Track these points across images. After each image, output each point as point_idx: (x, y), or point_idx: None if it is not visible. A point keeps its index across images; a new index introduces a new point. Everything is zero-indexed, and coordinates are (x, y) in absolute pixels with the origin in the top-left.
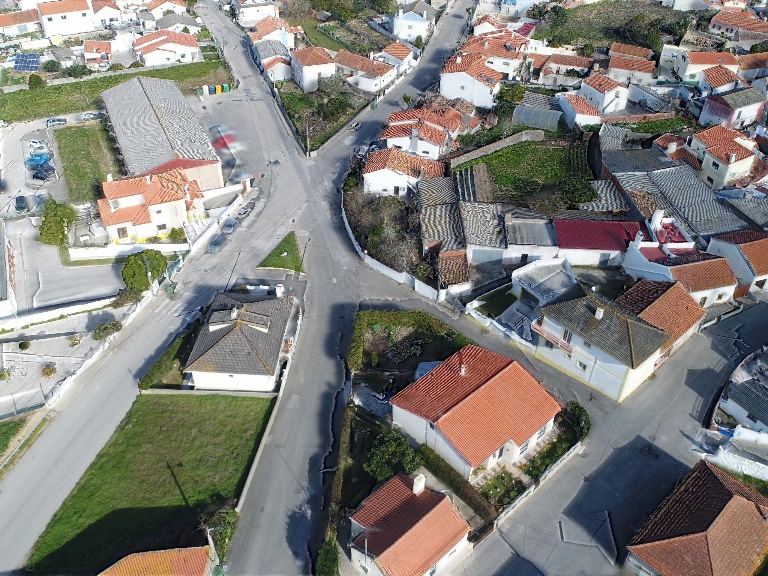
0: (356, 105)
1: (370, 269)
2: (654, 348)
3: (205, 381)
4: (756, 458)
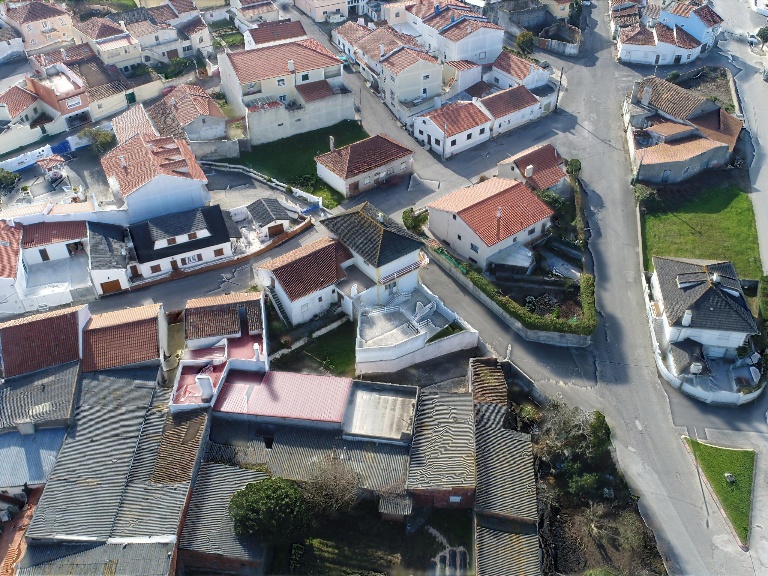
0: None
1: None
2: None
3: None
4: (297, 202)
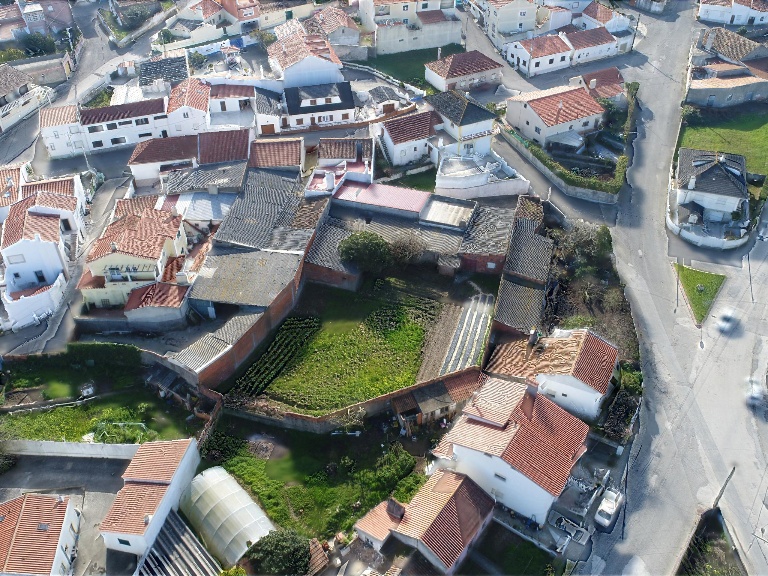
0: None
1: None
2: None
3: None
4: None
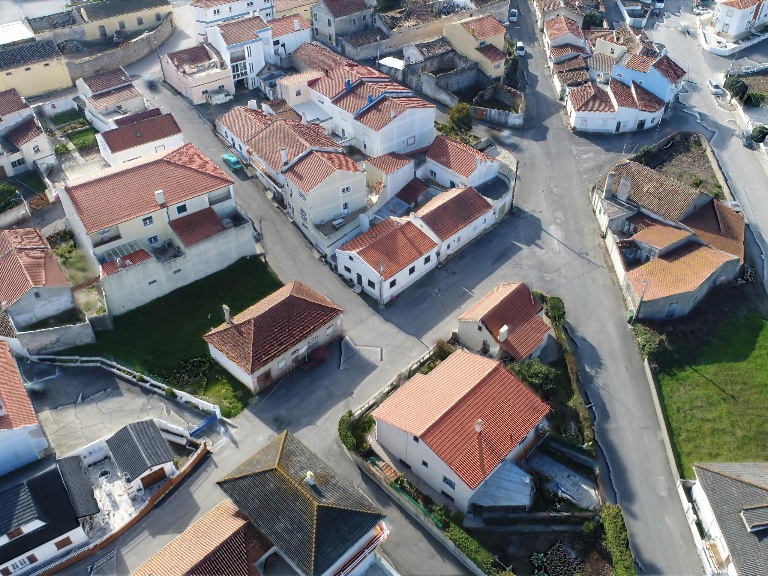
0: None
1: None
2: None
3: None
4: (183, 413)
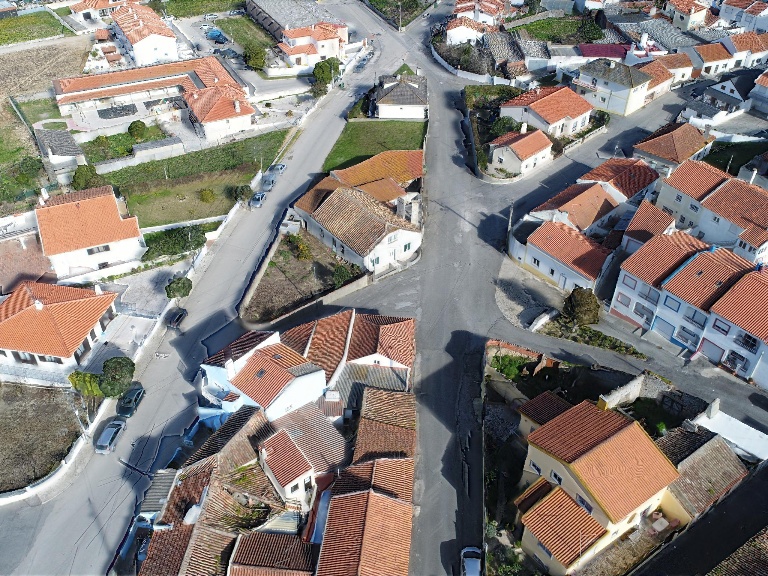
0: (424, 4)
1: (462, 78)
2: (644, 81)
3: (386, 112)
4: None
